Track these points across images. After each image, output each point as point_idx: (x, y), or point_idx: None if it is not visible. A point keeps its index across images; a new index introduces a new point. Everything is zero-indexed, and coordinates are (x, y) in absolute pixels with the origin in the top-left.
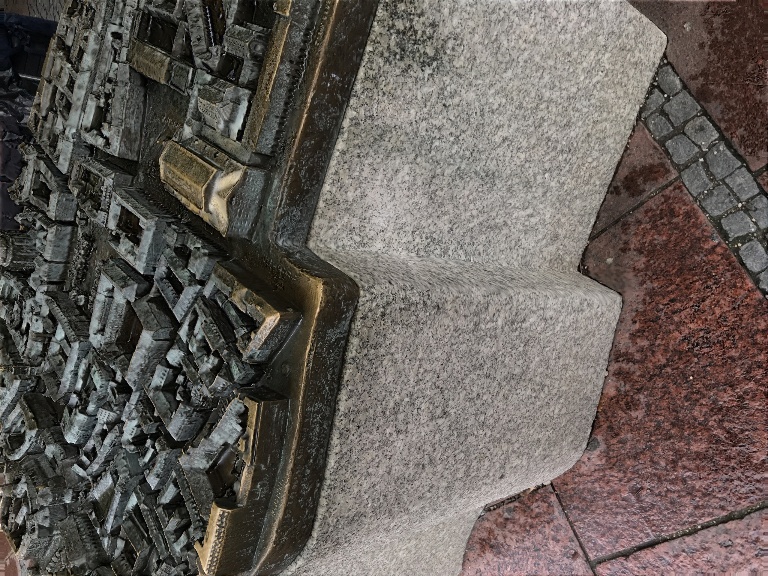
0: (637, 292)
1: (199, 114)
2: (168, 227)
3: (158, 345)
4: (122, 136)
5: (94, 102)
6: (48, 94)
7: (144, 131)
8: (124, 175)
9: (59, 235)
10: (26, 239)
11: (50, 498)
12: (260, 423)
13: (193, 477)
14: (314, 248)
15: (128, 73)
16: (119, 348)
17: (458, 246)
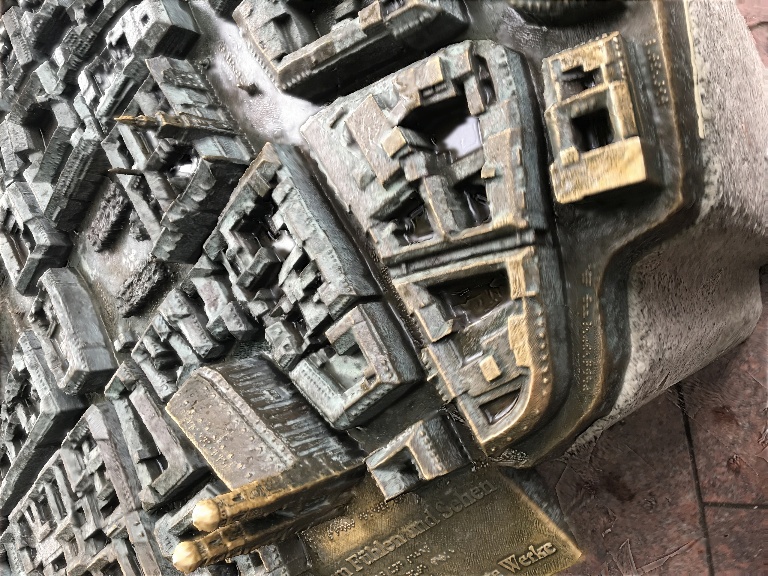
0: None
1: None
2: None
3: None
4: None
5: None
6: None
7: None
8: None
9: None
10: None
11: None
12: None
13: None
14: None
15: None
16: None
17: None
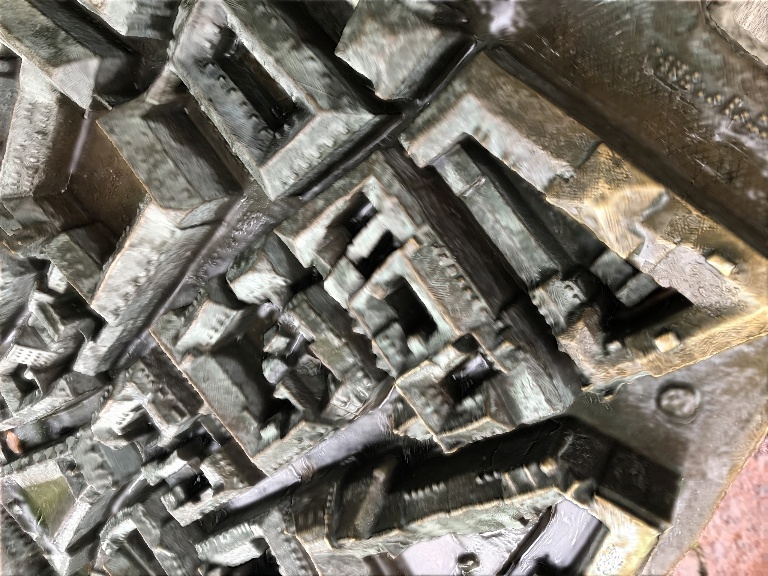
0: None
1: None
2: None
3: (184, 236)
4: None
5: None
6: None
7: None
8: None
9: None
10: None
11: None
12: (648, 572)
13: (338, 575)
14: (737, 32)
15: None
16: (46, 212)
17: (765, 23)
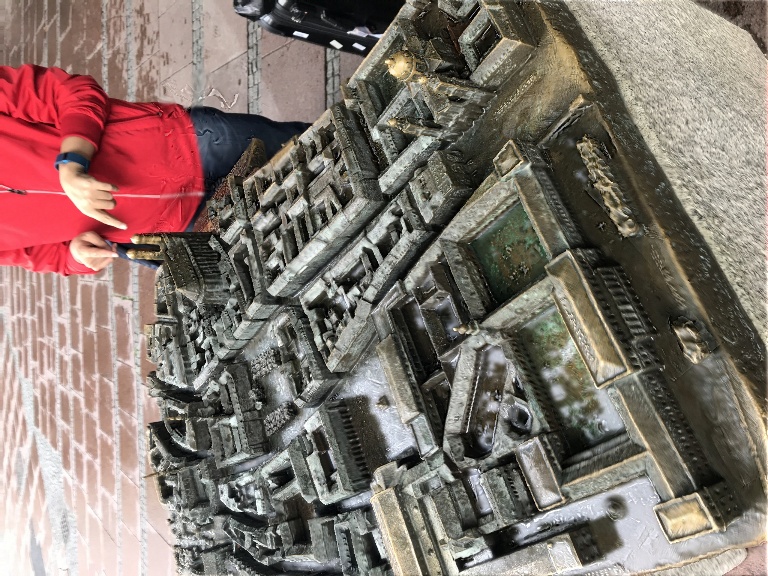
0: (764, 563)
1: (428, 484)
2: (362, 515)
3: None
4: (342, 359)
5: (323, 287)
6: (274, 192)
7: (364, 354)
8: (332, 380)
9: (251, 326)
10: (217, 284)
11: (198, 518)
12: None
13: None
14: None
15: (368, 313)
16: (285, 509)
17: None
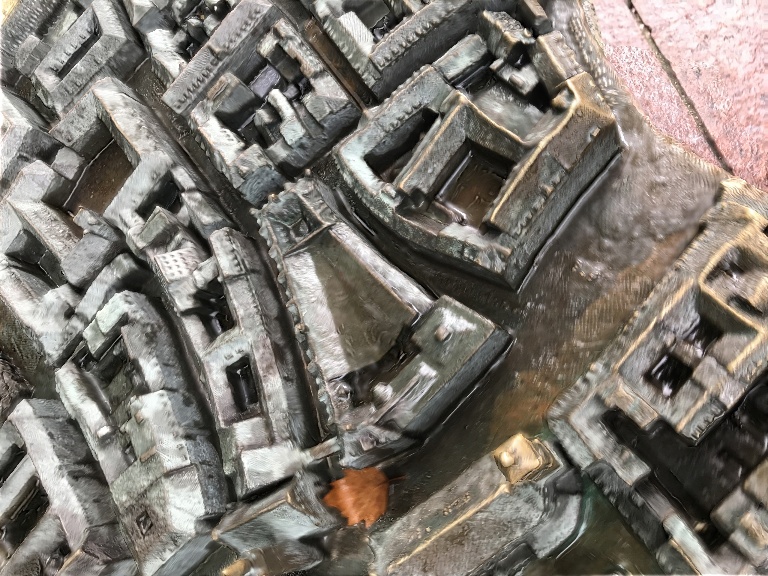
0: None
1: None
2: None
3: None
4: None
5: None
6: None
7: None
8: None
9: None
10: None
11: None
12: None
13: None
14: None
15: None
16: None
17: None
